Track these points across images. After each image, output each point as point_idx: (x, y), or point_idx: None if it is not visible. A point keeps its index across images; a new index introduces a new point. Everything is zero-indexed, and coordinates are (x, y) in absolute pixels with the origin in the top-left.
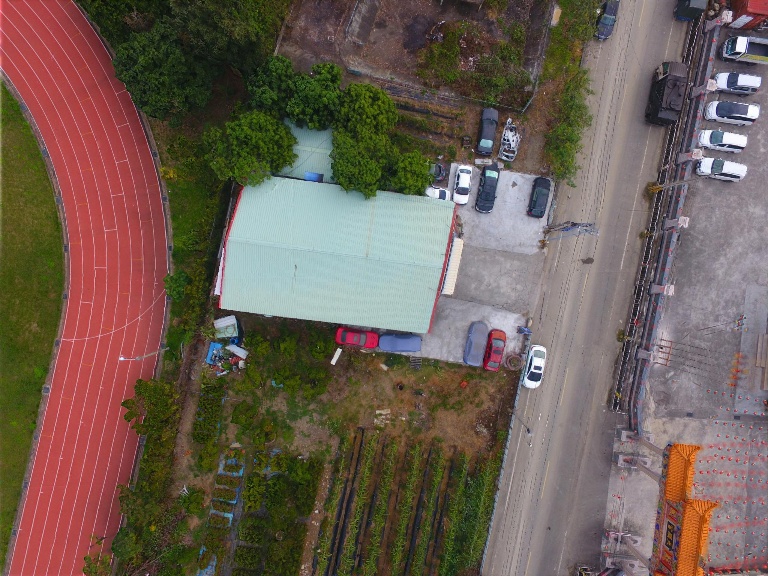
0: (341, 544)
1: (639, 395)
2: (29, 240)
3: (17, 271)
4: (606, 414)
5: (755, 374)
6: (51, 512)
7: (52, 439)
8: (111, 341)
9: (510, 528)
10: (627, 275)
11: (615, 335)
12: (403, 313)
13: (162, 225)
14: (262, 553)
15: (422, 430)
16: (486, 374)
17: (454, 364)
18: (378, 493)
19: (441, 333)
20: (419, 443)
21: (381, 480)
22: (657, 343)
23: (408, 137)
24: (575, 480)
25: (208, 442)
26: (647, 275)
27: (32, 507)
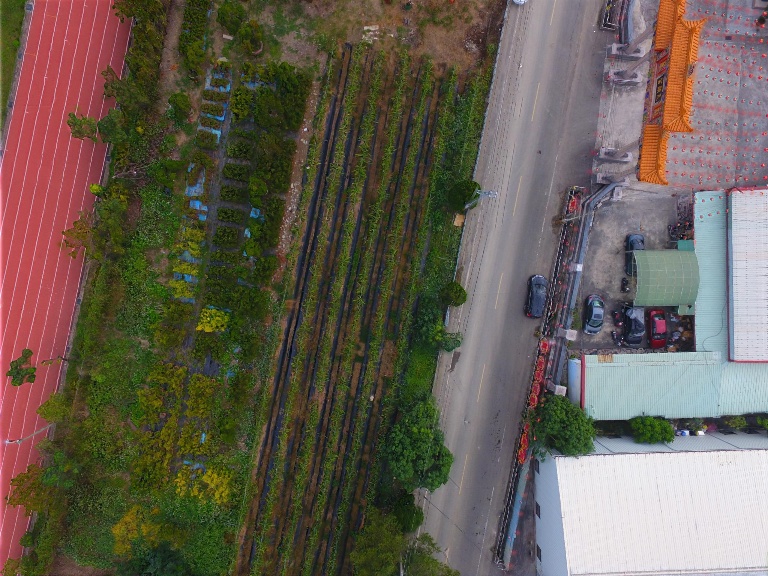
0: None
1: (629, 4)
2: None
3: None
4: (596, 35)
5: None
6: (37, 133)
7: (36, 58)
8: None
9: (500, 151)
10: None
11: None
12: None
13: None
14: (251, 170)
15: (411, 47)
16: None
17: None
18: None
19: None
20: (408, 57)
21: (370, 87)
22: None
23: None
24: (565, 103)
25: (194, 42)
26: None
27: (17, 127)
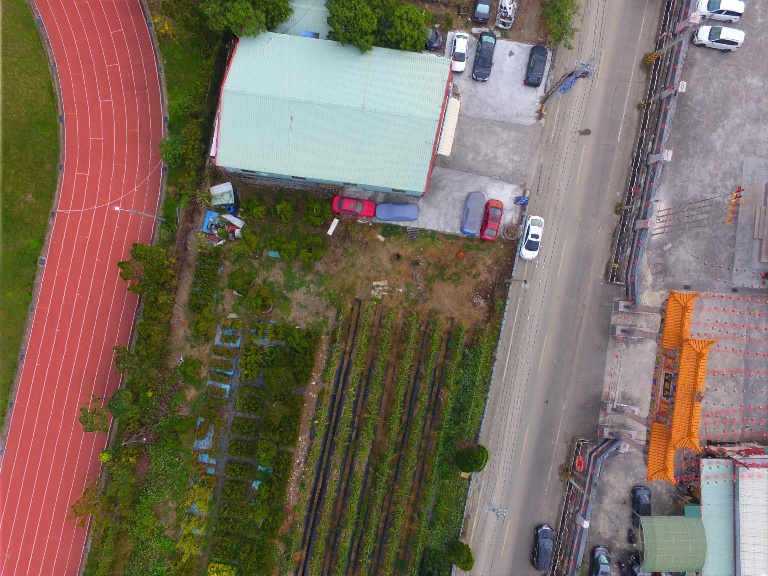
0: (338, 416)
1: (636, 264)
2: (24, 110)
3: (12, 141)
4: (604, 287)
5: (753, 246)
6: (48, 384)
7: (48, 311)
8: (107, 213)
9: (508, 401)
10: (624, 147)
11: (612, 208)
12: (400, 169)
13: (157, 96)
14: (259, 424)
15: (419, 302)
16: (483, 245)
17: (451, 235)
18: (375, 363)
19: (438, 204)
20: (416, 314)
21: (378, 348)
22: (654, 199)
23: (404, 4)
24: (573, 353)
25: (205, 308)
26: (644, 147)
27: (28, 379)
